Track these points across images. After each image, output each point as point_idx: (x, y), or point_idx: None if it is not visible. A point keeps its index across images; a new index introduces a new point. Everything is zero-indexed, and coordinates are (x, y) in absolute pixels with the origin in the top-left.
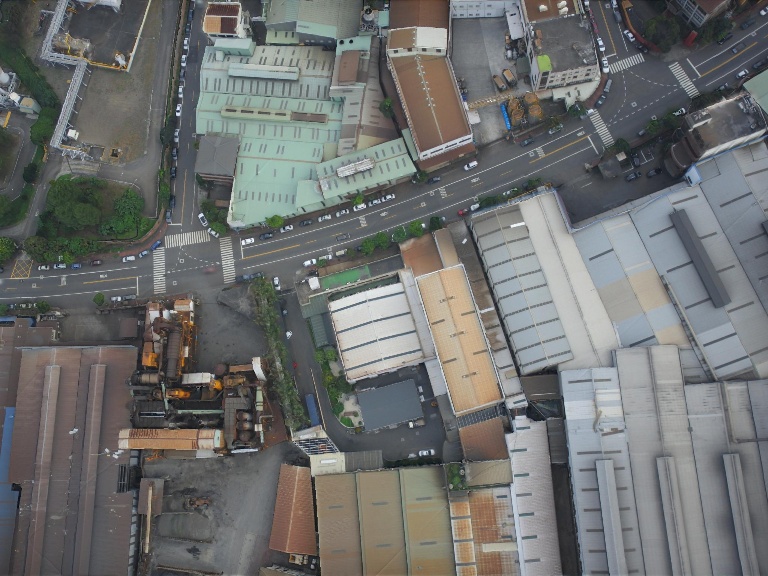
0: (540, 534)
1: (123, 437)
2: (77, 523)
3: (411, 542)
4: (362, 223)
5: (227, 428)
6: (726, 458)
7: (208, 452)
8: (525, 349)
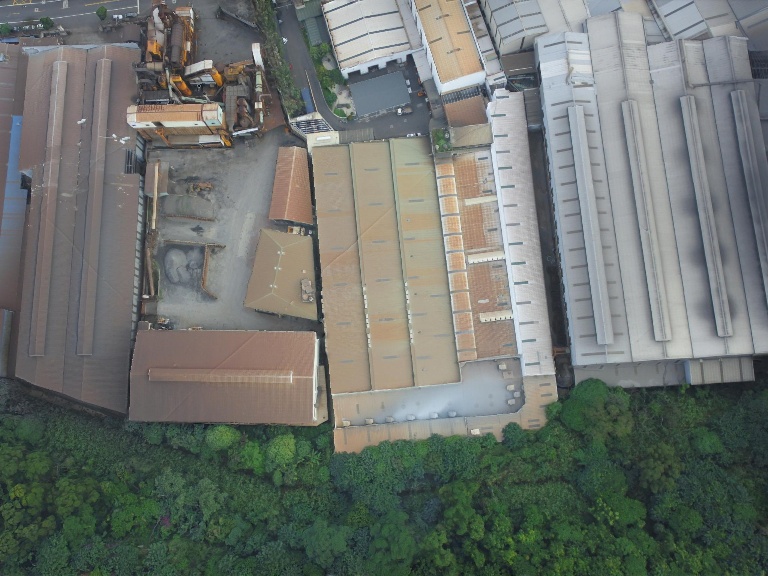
0: (517, 184)
1: (131, 112)
2: (88, 196)
3: (400, 199)
4: None
5: (228, 112)
6: (683, 99)
7: (210, 138)
8: (505, 24)
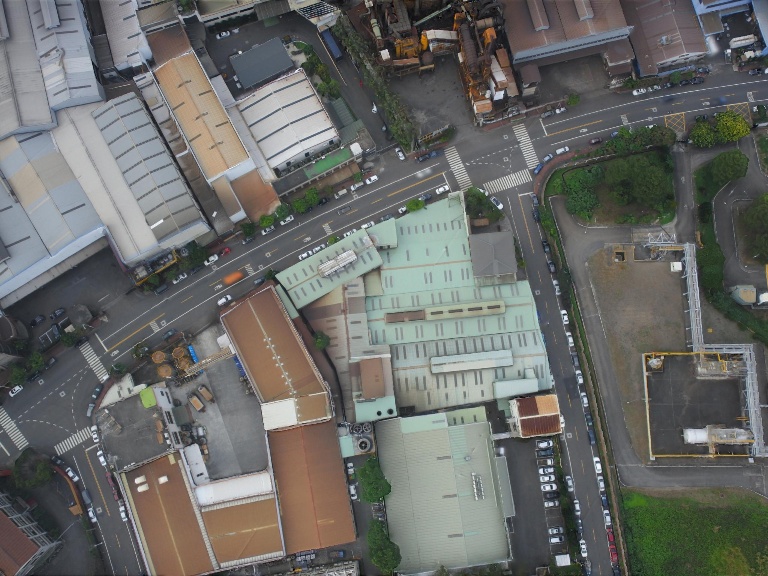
0: None
1: None
2: None
3: None
4: (328, 227)
5: (402, 5)
6: None
7: None
8: (135, 111)
